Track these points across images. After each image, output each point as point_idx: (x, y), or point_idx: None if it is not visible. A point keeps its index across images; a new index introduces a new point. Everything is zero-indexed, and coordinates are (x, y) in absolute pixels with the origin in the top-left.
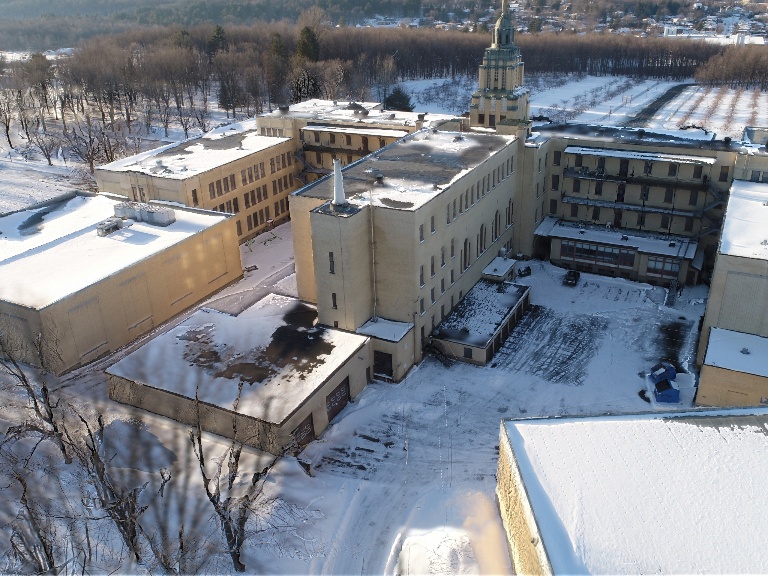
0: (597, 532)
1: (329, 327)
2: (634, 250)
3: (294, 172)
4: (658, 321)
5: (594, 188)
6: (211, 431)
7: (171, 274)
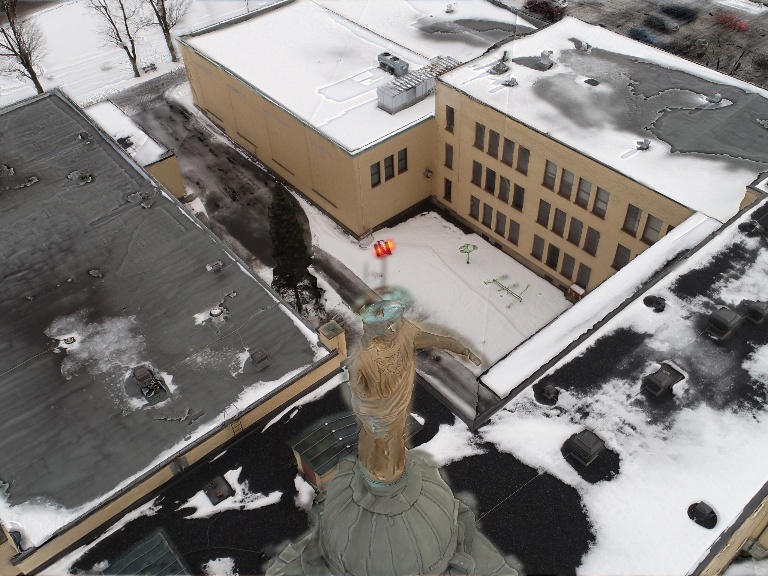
0: None
1: None
2: None
3: None
4: None
5: None
6: None
7: (273, 130)
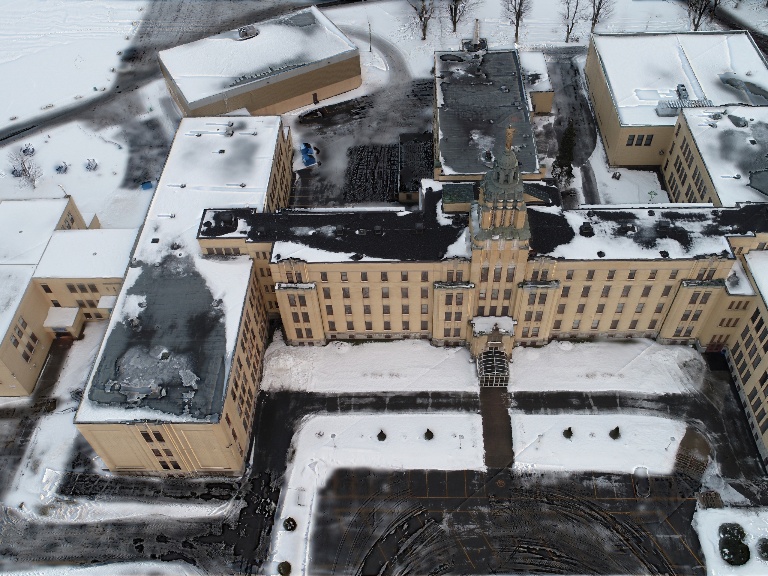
0: (321, 31)
1: None
2: None
3: None
4: None
5: None
6: None
7: None
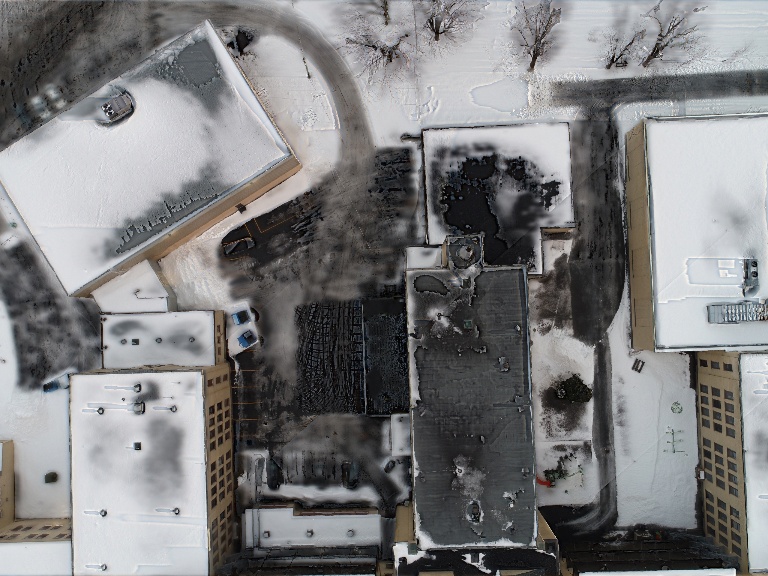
0: (230, 102)
1: None
2: None
3: None
4: (266, 429)
5: None
6: None
7: None
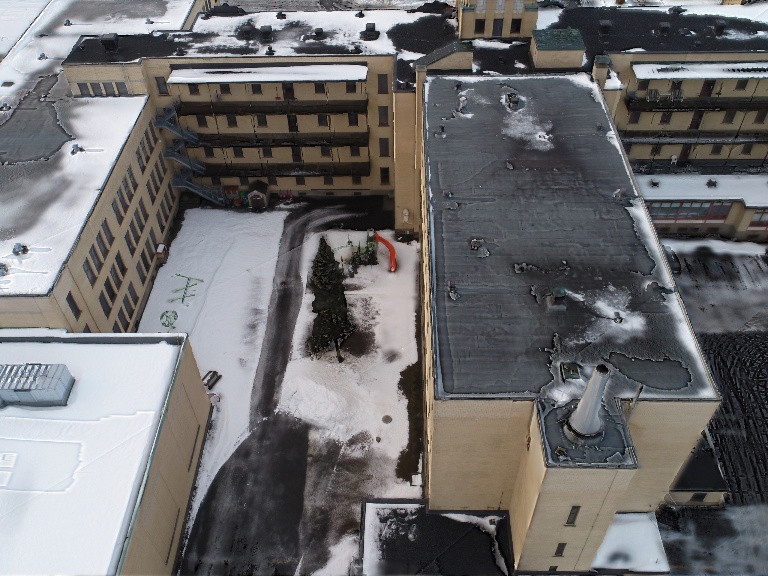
0: None
1: (538, 573)
2: (733, 201)
3: (162, 148)
4: None
5: (660, 116)
6: None
7: (153, 525)
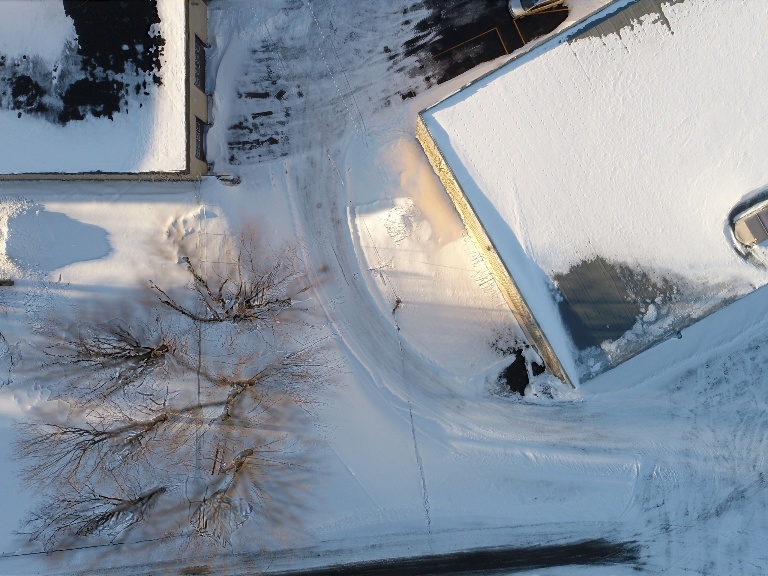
0: (537, 224)
1: None
2: None
3: None
4: None
5: None
6: (107, 180)
7: None
